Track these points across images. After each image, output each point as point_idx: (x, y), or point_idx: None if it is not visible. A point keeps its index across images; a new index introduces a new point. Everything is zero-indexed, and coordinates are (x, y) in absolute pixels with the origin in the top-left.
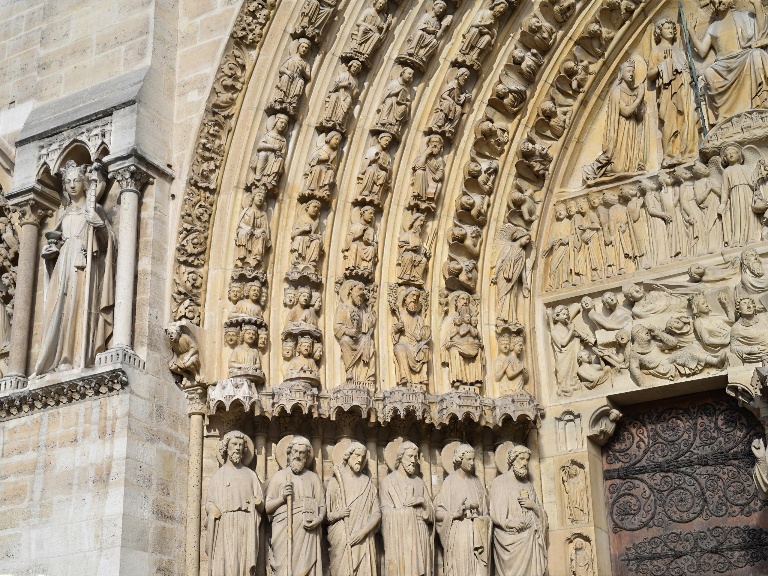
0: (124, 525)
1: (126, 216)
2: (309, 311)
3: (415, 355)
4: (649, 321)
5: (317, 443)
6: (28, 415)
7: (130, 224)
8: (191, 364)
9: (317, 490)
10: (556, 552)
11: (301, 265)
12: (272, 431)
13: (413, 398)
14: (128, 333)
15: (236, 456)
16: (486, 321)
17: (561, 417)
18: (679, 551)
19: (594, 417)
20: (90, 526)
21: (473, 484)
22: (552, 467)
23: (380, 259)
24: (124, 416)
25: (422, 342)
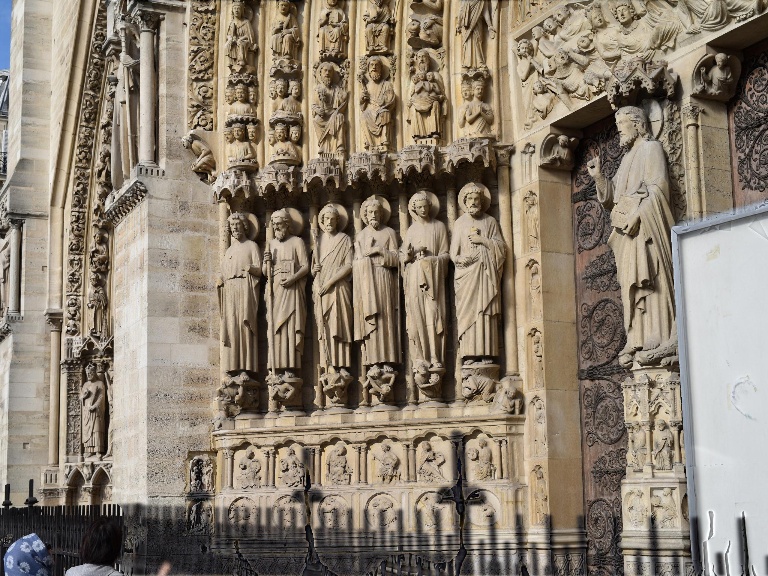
0: (150, 300)
1: (142, 54)
2: (286, 100)
3: (375, 120)
4: (571, 43)
5: (312, 211)
6: (122, 221)
7: (145, 60)
8: (202, 164)
9: (299, 252)
10: (520, 278)
11: (277, 60)
12: (281, 206)
13: (364, 161)
14: (149, 150)
15: (235, 234)
16: (453, 71)
17: (525, 150)
18: (615, 266)
19: (543, 147)
20: (139, 302)
21: (431, 228)
22: (519, 199)
23: (351, 36)
24: (147, 217)
25: (382, 107)
